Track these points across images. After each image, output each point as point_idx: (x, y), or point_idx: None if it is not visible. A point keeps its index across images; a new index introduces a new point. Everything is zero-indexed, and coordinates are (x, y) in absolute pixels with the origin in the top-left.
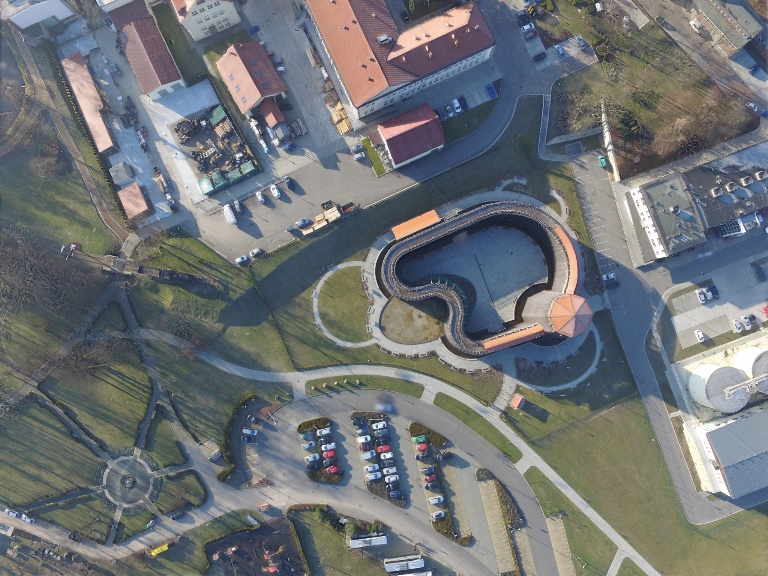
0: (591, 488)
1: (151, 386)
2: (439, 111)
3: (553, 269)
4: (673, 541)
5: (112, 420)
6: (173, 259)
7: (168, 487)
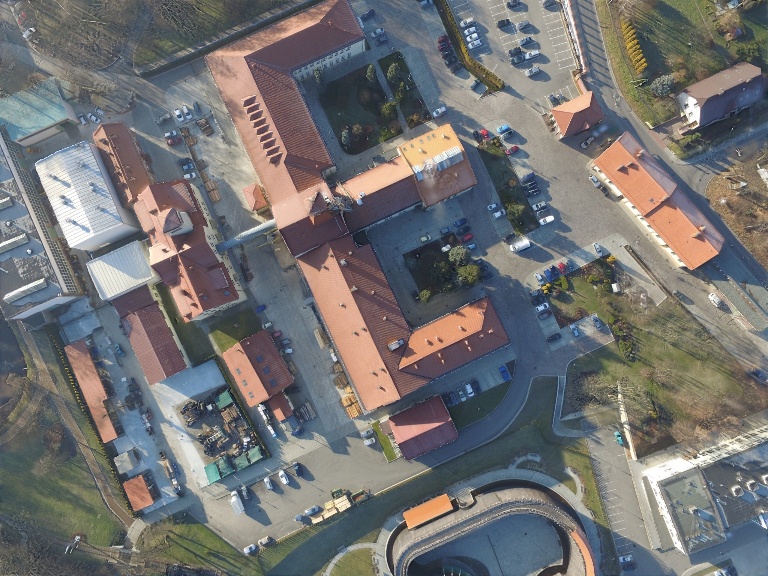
0: None
1: None
2: (451, 397)
3: (568, 550)
4: None
5: None
6: (180, 550)
7: None
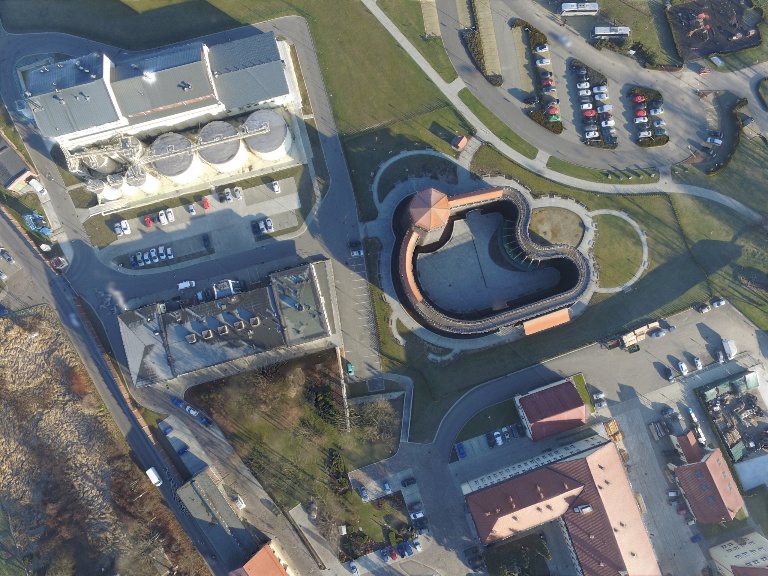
0: (396, 58)
1: None
2: (518, 434)
3: None
4: (323, 4)
5: None
6: None
7: None
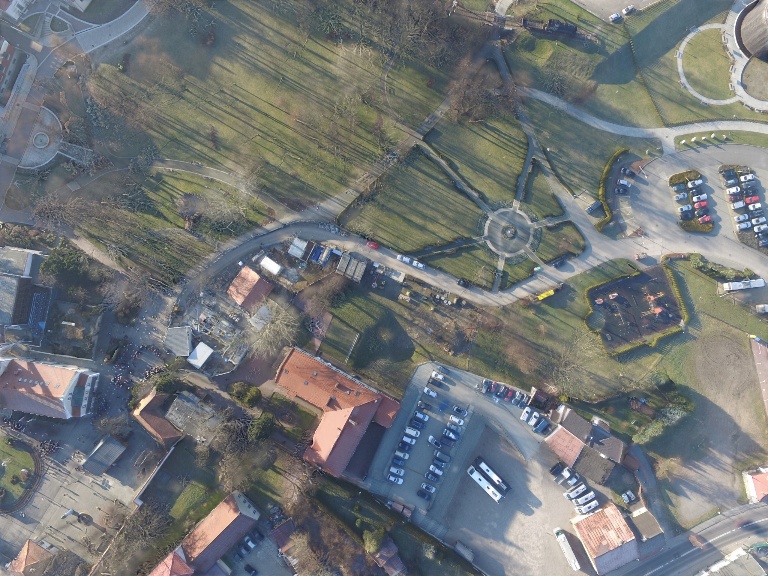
0: None
1: (527, 141)
2: None
3: None
4: None
5: (490, 174)
6: (551, 15)
7: (547, 237)
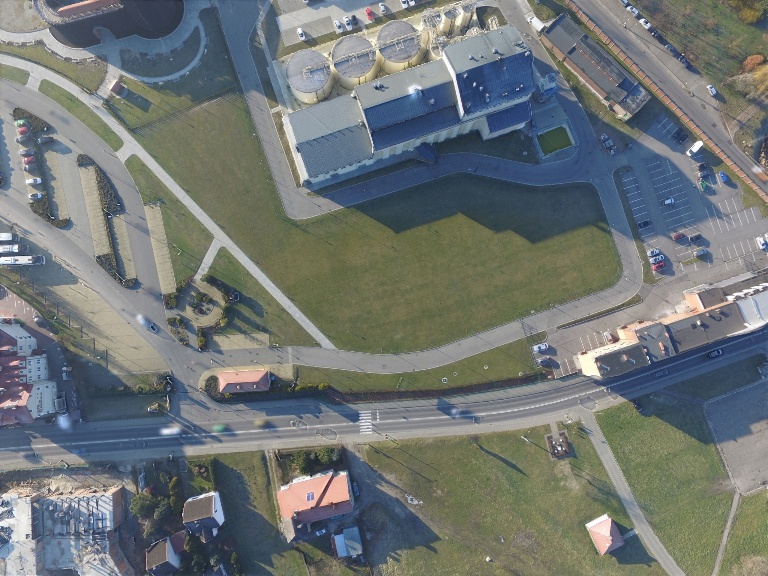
0: (190, 178)
1: None
2: None
3: None
4: (270, 234)
5: None
6: None
7: None
